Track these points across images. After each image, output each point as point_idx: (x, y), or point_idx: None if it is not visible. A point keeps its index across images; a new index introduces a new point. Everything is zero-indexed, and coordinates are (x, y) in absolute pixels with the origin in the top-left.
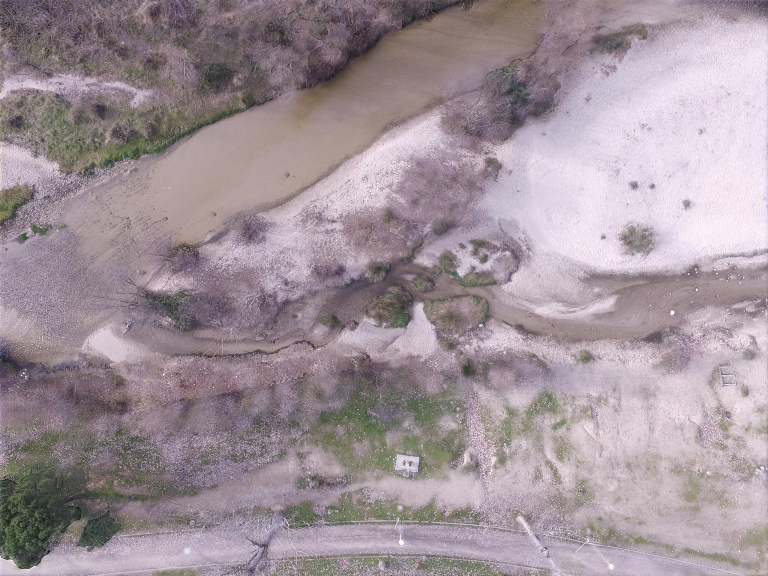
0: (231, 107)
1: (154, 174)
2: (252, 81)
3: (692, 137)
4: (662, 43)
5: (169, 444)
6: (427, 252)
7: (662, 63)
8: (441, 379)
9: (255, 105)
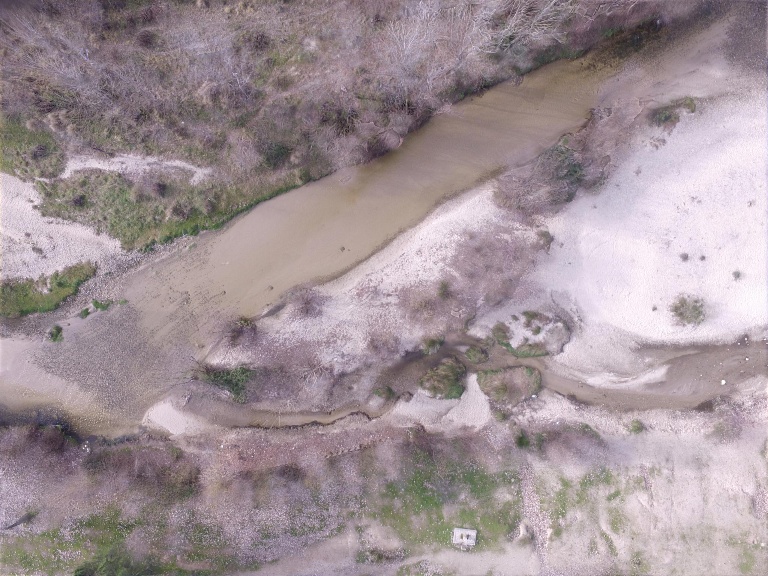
0: (288, 184)
1: (212, 249)
2: (308, 158)
3: (741, 209)
4: (710, 116)
5: (229, 517)
6: (480, 324)
7: (710, 136)
8: (495, 450)
9: (311, 181)
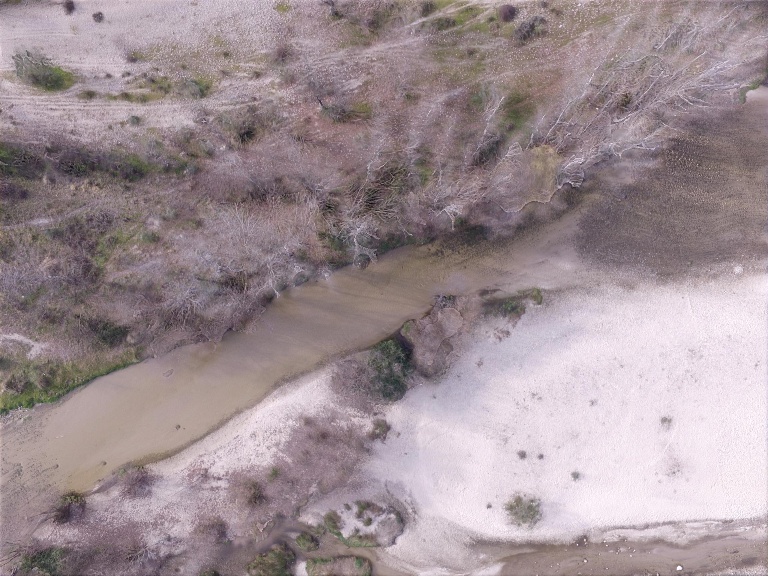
0: (125, 360)
1: (47, 422)
2: (146, 336)
3: (583, 408)
4: (557, 309)
5: None
6: (312, 511)
7: (556, 330)
8: None
9: (149, 357)
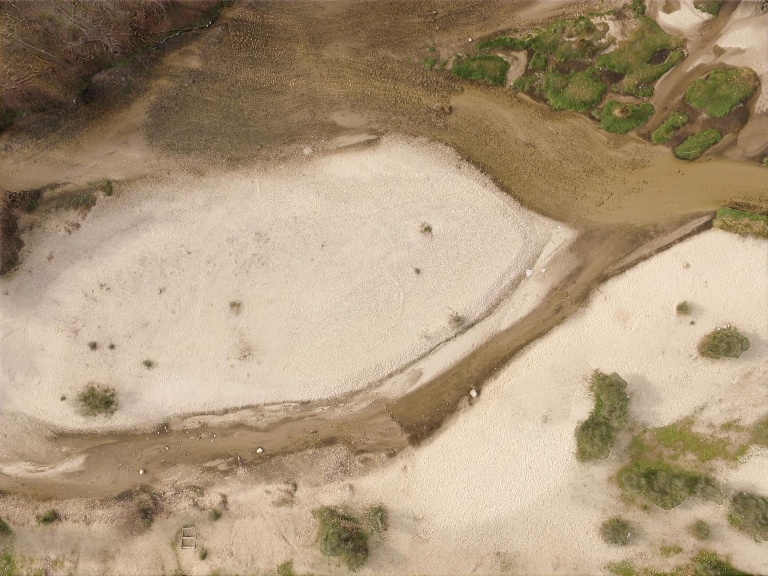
0: None
1: None
2: None
3: (152, 297)
4: (127, 200)
5: None
6: None
7: (126, 220)
8: None
9: None
